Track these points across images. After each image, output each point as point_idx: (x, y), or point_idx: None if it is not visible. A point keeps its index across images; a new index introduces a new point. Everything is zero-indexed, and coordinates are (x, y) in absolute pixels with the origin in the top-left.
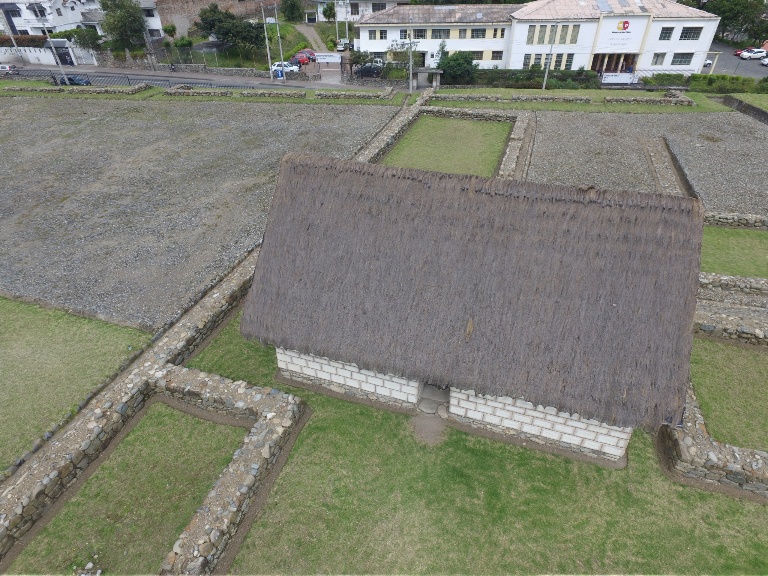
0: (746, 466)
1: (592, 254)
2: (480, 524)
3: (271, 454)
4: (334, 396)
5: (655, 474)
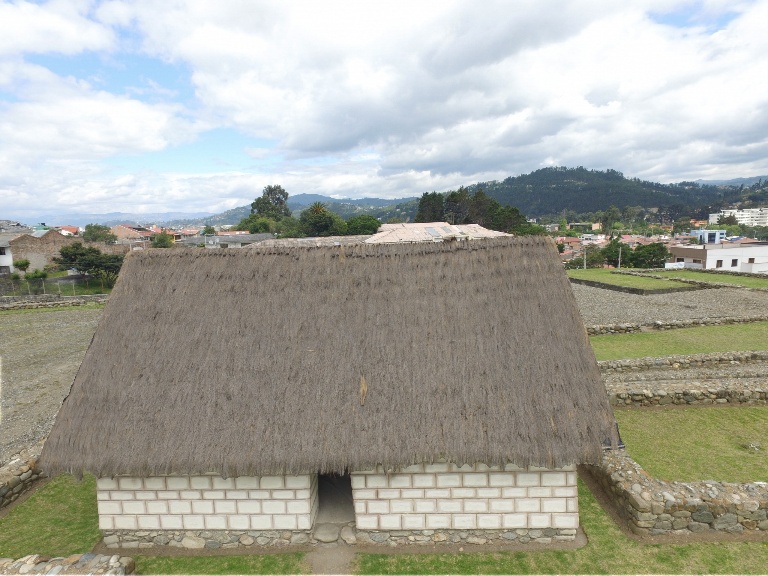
0: (704, 496)
1: (473, 291)
2: None
3: None
4: (188, 554)
5: (622, 541)
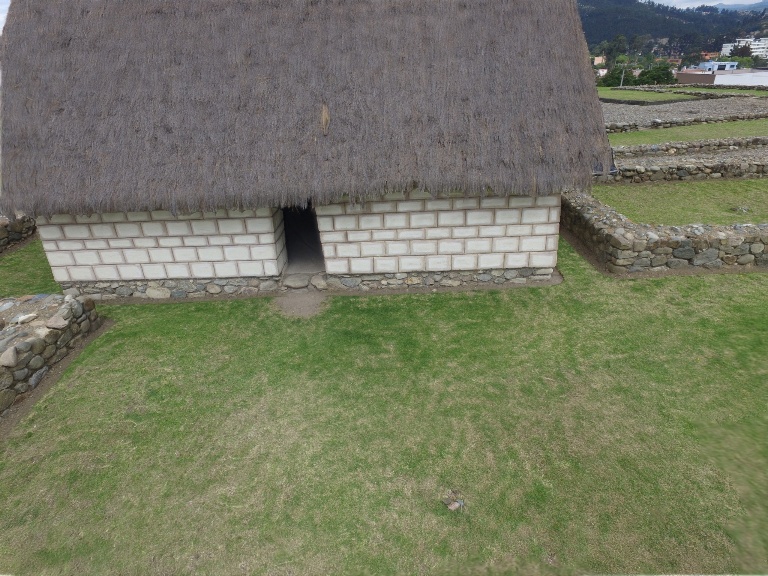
0: (690, 234)
1: (459, 7)
2: (397, 377)
3: (20, 363)
4: (153, 303)
5: (598, 278)
